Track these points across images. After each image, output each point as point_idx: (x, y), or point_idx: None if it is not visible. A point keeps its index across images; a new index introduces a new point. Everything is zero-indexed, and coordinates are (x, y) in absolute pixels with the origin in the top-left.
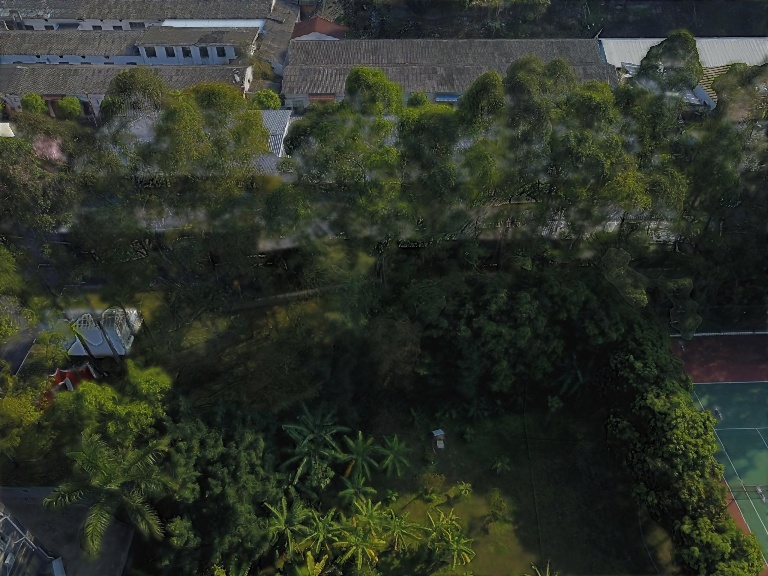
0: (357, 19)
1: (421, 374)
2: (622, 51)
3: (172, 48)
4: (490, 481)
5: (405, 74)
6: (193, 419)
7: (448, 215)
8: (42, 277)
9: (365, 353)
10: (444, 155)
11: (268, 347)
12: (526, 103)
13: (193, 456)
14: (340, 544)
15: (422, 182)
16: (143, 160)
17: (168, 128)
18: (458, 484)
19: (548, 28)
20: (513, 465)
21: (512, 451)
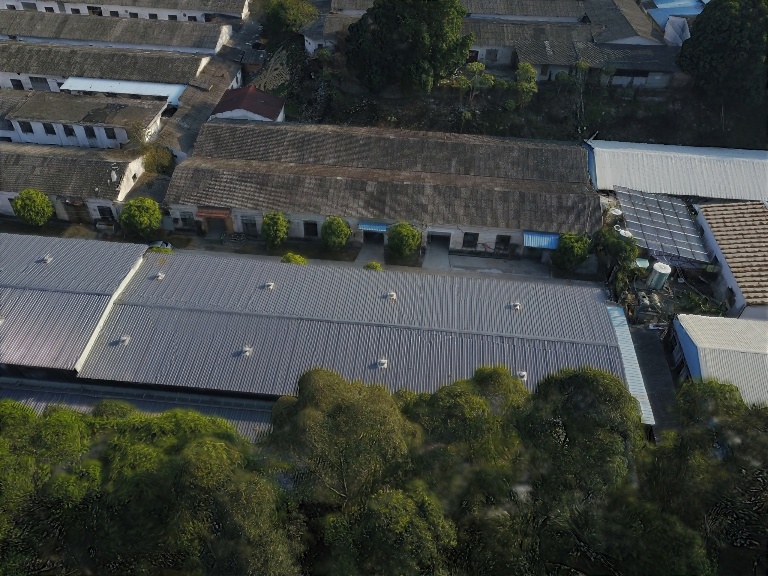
0: (302, 90)
1: None
2: (618, 166)
3: (51, 125)
4: None
5: (325, 188)
6: None
7: None
8: None
9: None
10: (135, 570)
11: None
12: (244, 557)
13: None
14: None
15: None
16: None
17: None
18: None
19: (533, 120)
20: None
21: None
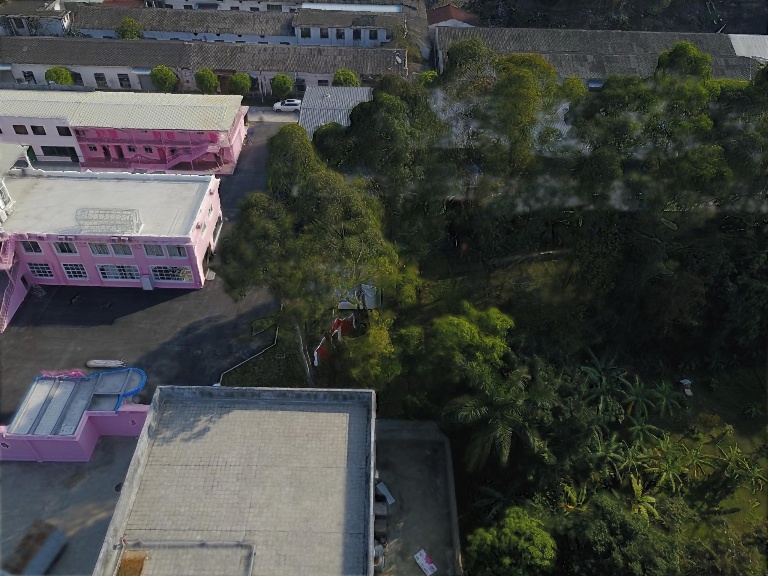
0: (484, 8)
1: (694, 325)
2: (749, 46)
3: (327, 30)
4: (745, 424)
5: (558, 61)
6: (524, 355)
7: (752, 178)
8: (391, 224)
9: (646, 304)
10: (746, 124)
11: (503, 305)
12: None
13: (554, 383)
14: (653, 470)
15: (732, 147)
16: (466, 122)
17: (518, 91)
18: (717, 426)
19: (669, 22)
20: (761, 411)
21: (756, 399)
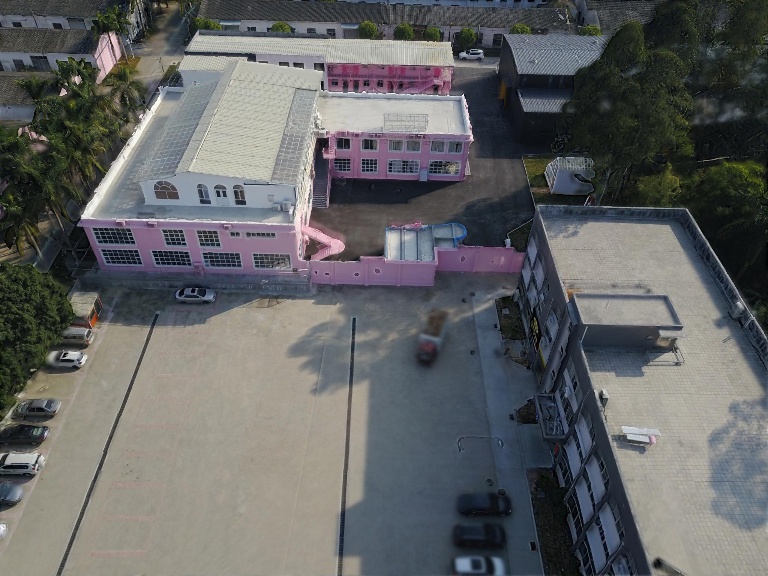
0: None
1: None
2: None
3: None
4: None
5: None
6: None
7: None
8: None
9: None
10: None
11: None
12: None
13: None
14: None
15: None
16: None
17: None
18: None
19: None
20: None
21: None
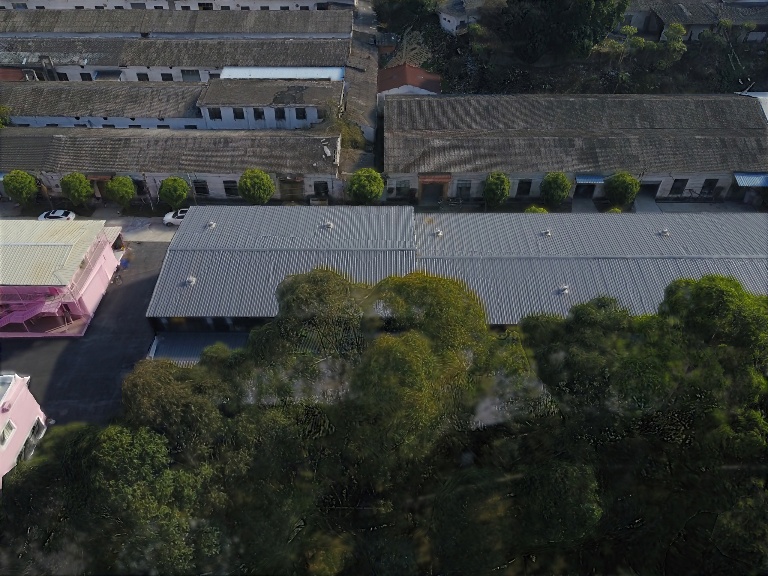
0: (450, 65)
1: None
2: None
3: (241, 109)
4: None
5: (536, 147)
6: None
7: None
8: None
9: None
10: None
11: None
12: None
13: None
14: None
15: None
16: None
17: (391, 391)
18: None
19: (681, 78)
20: None
21: None
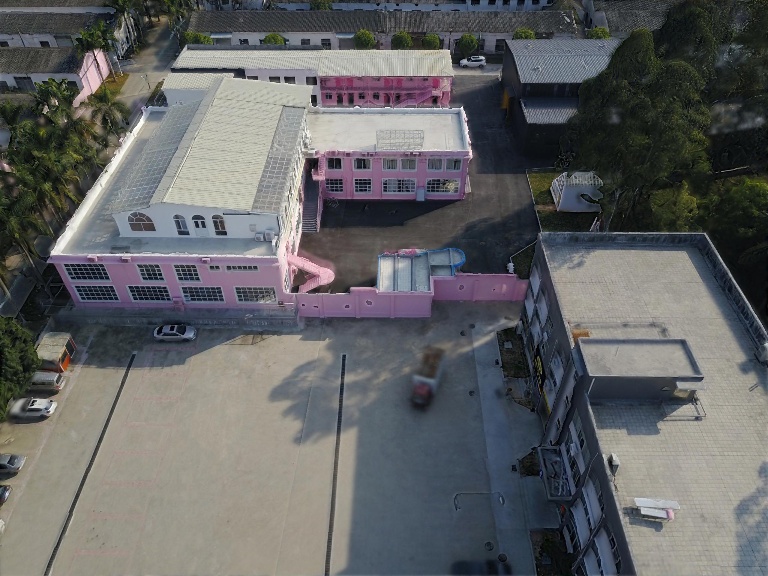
0: None
1: None
2: None
3: None
4: None
5: None
6: None
7: None
8: None
9: None
10: None
11: None
12: None
13: None
14: None
15: None
16: (734, 38)
17: None
18: None
19: None
20: None
21: None
